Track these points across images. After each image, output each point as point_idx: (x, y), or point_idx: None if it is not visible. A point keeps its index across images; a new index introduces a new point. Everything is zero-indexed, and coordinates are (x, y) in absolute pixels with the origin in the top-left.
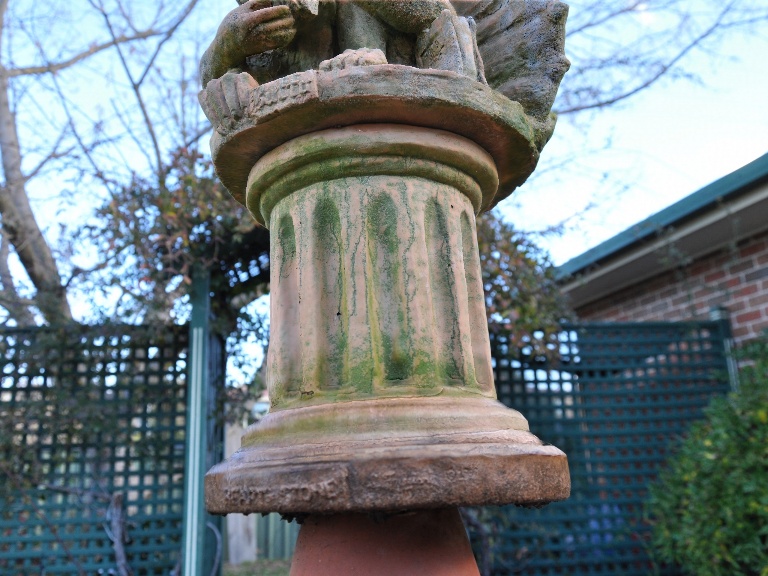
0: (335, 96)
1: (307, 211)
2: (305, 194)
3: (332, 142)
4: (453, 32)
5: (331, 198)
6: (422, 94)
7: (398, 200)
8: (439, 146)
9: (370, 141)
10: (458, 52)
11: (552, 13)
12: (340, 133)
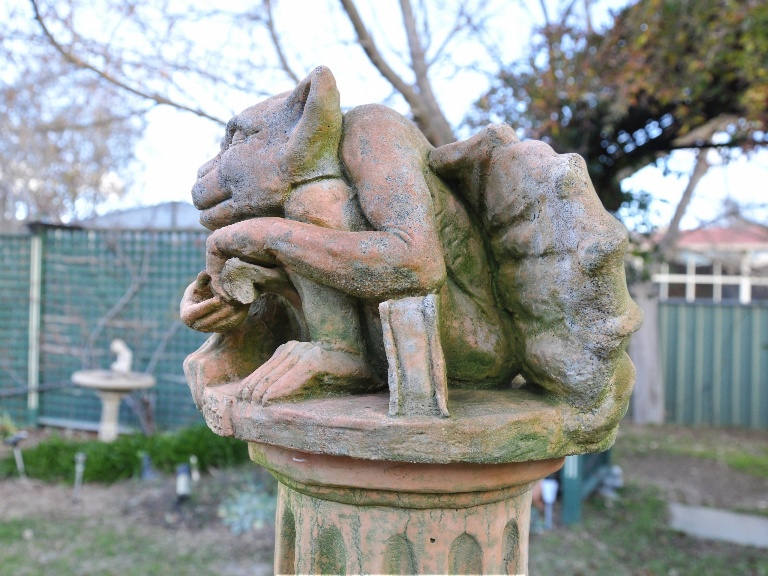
0: (245, 437)
1: (279, 512)
2: (280, 489)
3: (272, 465)
4: (387, 342)
5: (292, 511)
6: (331, 449)
7: (349, 540)
8: (387, 486)
9: (302, 477)
10: (392, 374)
11: (583, 262)
12: (278, 456)
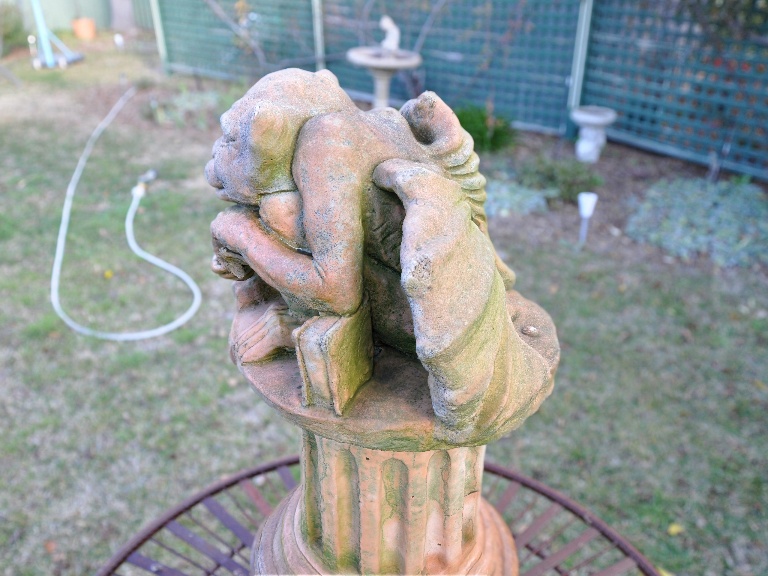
0: None
1: None
2: None
3: None
4: (298, 360)
5: None
6: None
7: (318, 441)
8: None
9: None
10: (303, 380)
11: None
12: None
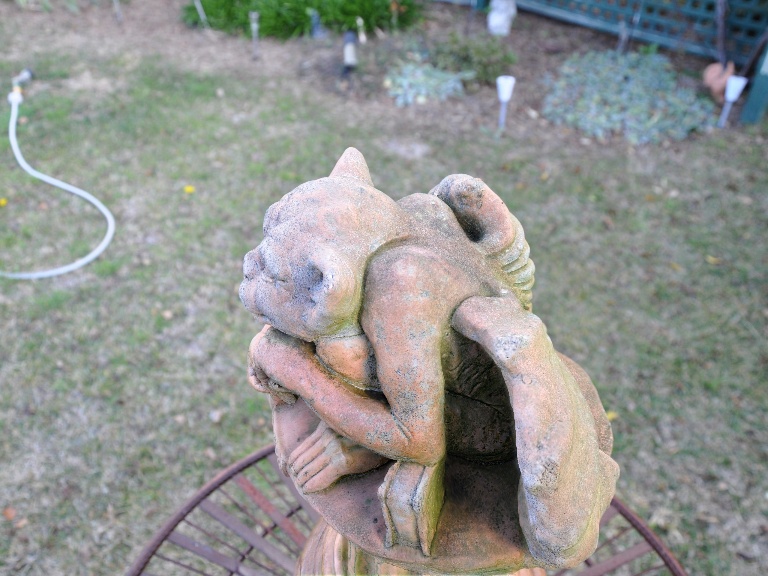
0: None
1: None
2: None
3: None
4: (384, 514)
5: None
6: None
7: None
8: None
9: None
10: (388, 529)
11: (537, 541)
12: None
